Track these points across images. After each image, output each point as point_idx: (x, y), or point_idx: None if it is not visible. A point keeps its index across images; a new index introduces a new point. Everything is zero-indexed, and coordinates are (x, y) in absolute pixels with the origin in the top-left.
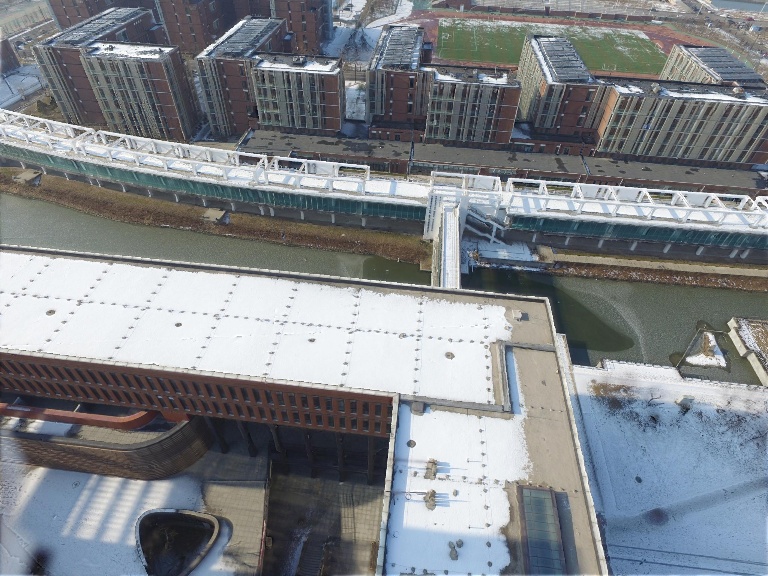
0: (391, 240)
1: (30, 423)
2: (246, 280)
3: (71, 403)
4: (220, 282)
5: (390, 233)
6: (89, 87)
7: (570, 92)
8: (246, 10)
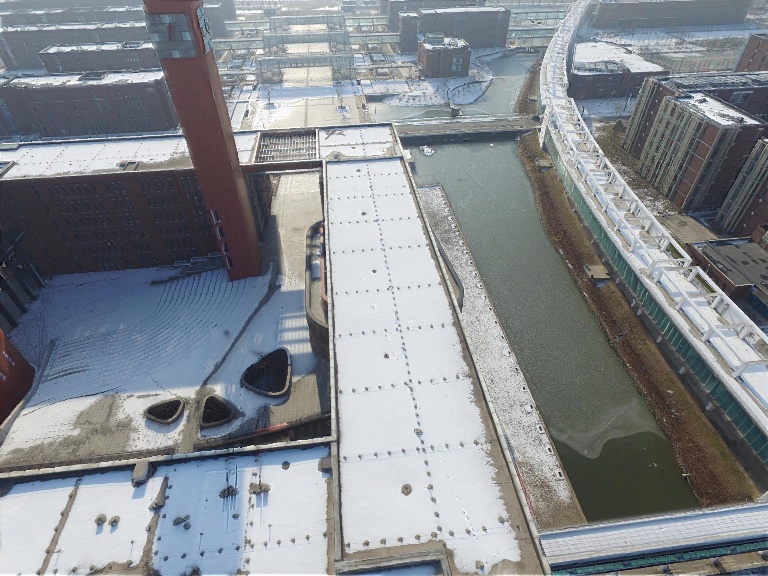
0: (713, 453)
1: (318, 260)
2: (438, 290)
3: None
4: (428, 276)
5: (725, 447)
6: None
7: None
8: None
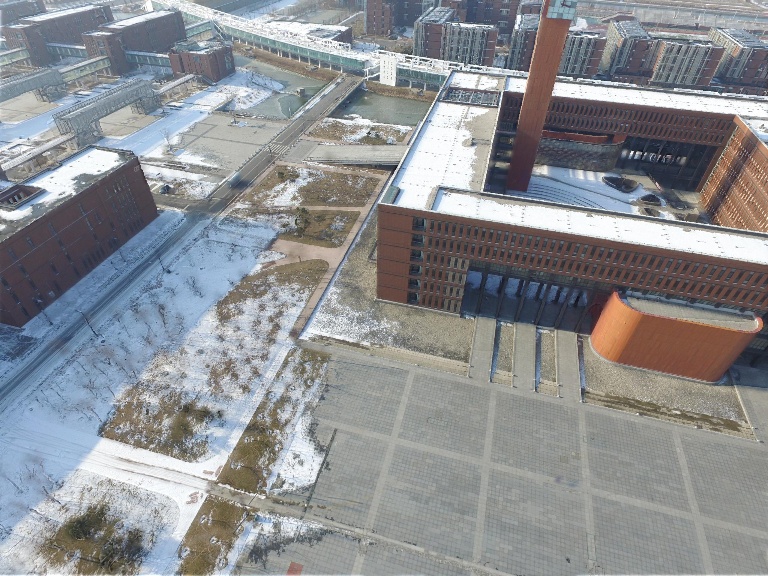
0: None
1: None
2: None
3: (574, 132)
4: (633, 91)
5: None
6: (436, 48)
7: (754, 54)
8: (482, 17)
